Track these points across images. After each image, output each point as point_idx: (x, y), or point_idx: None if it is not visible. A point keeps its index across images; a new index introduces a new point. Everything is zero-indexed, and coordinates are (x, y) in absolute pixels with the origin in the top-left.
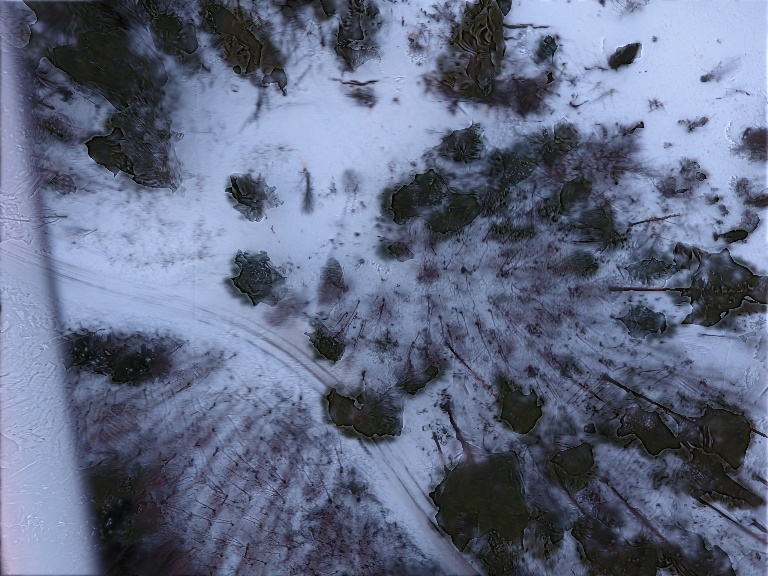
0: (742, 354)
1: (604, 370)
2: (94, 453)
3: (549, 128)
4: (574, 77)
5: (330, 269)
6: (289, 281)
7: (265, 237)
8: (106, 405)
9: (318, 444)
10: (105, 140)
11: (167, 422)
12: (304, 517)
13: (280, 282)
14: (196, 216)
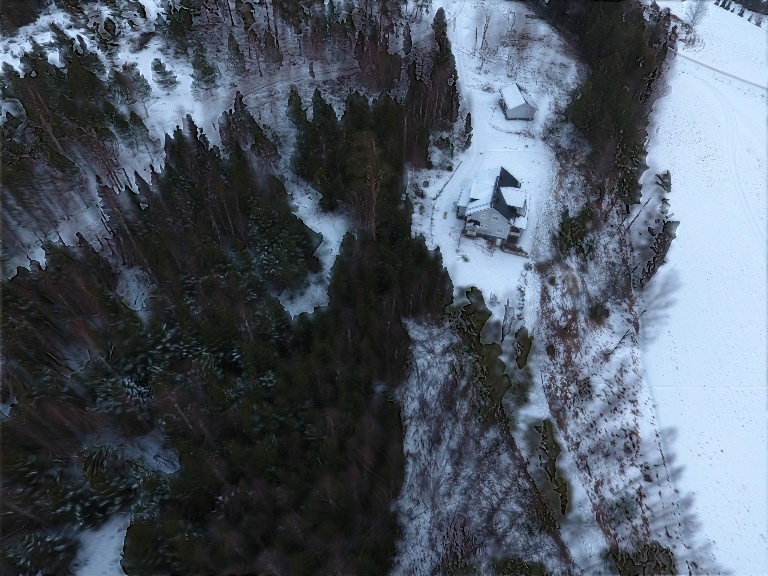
0: (264, 9)
1: (266, 30)
2: None
3: None
4: None
5: None
6: None
7: None
8: None
9: None
10: None
11: (280, 126)
12: None
13: None
14: (171, 112)
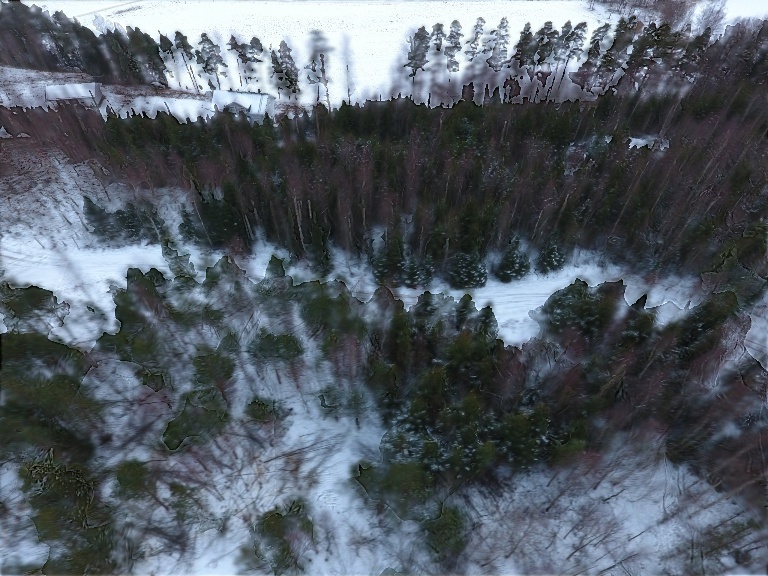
0: None
1: None
2: None
3: None
4: None
5: None
6: None
7: None
8: None
9: None
10: (23, 296)
11: (110, 212)
12: None
13: None
14: None
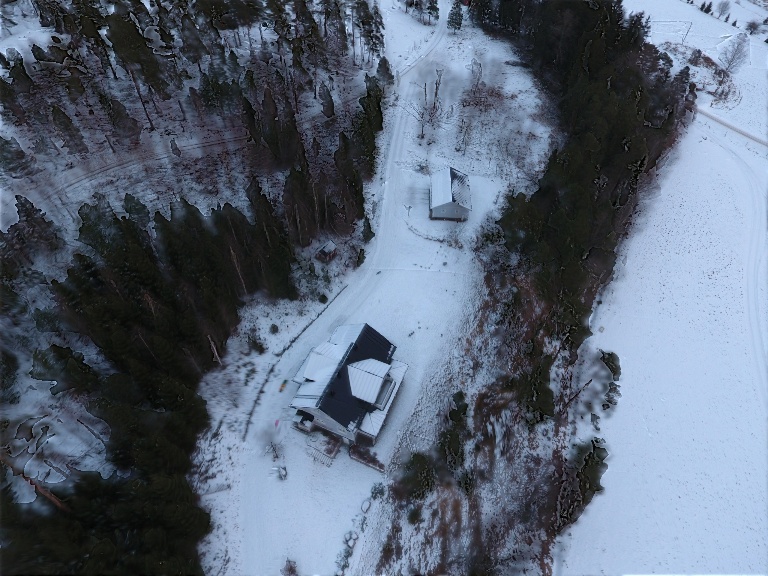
0: None
1: None
2: None
3: None
4: (4, 79)
5: (35, 147)
6: None
7: None
8: (63, 267)
9: (151, 174)
10: None
11: None
12: (197, 184)
13: None
14: None
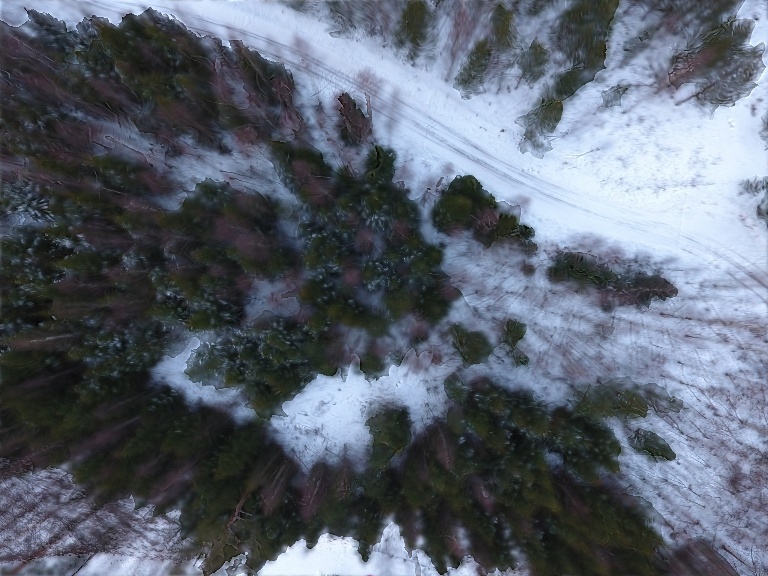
0: None
1: None
2: (552, 378)
3: None
4: None
5: None
6: None
7: (762, 168)
8: (570, 330)
9: None
10: (729, 44)
11: (634, 351)
12: (756, 461)
13: None
14: (695, 143)
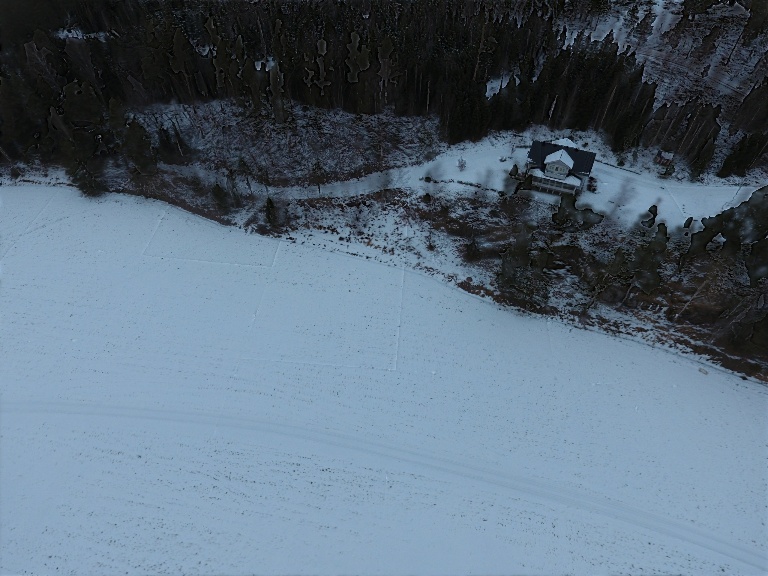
0: None
1: None
2: None
3: (717, 16)
4: None
5: None
6: (645, 44)
7: None
8: None
9: None
10: None
11: None
12: (683, 91)
13: (651, 29)
14: None
